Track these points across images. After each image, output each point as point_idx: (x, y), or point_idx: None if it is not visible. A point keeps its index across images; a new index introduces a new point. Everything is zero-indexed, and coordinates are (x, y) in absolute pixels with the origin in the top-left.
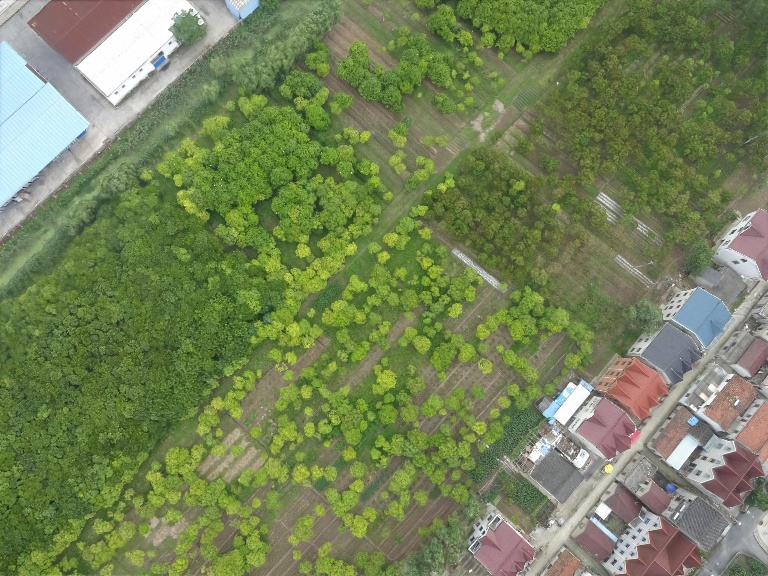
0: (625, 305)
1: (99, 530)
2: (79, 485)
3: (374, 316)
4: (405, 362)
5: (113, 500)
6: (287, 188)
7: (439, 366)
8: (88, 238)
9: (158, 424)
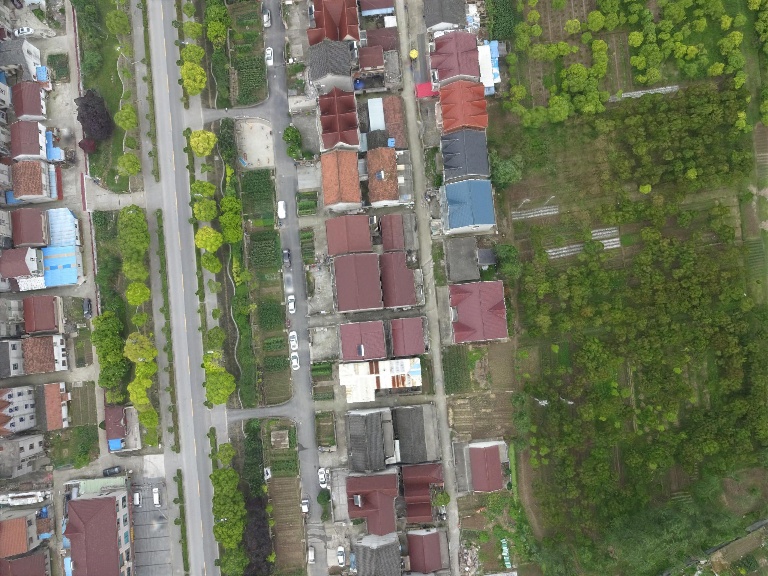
0: None
1: None
2: None
3: None
4: None
5: None
6: None
7: None
8: None
9: None
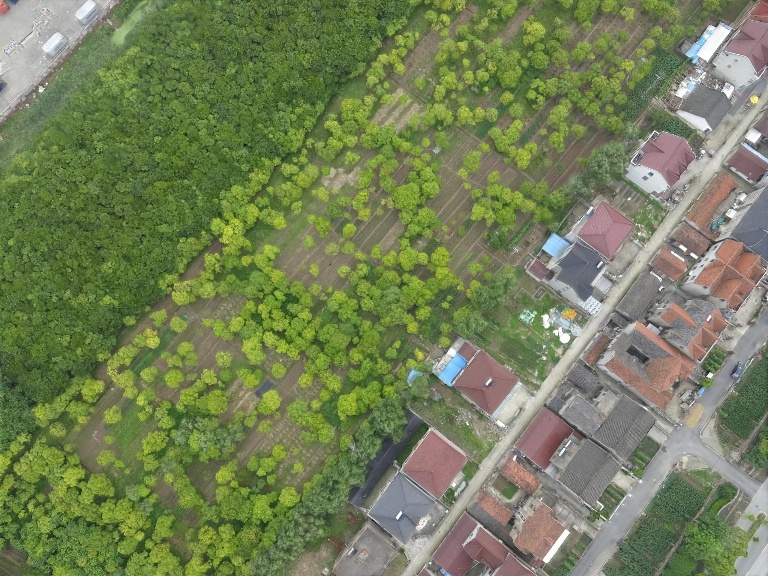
0: None
1: (287, 171)
2: (268, 128)
3: None
4: (549, 21)
5: (298, 144)
6: None
7: (585, 13)
8: None
9: (332, 77)
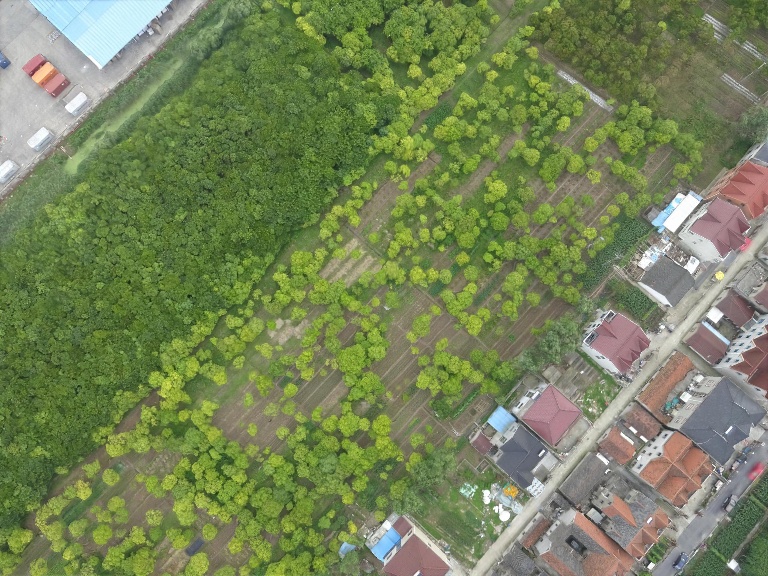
0: (733, 120)
1: (231, 324)
2: (214, 280)
3: (485, 127)
4: (514, 176)
5: (244, 296)
6: (400, 10)
7: (549, 175)
8: (216, 59)
9: (284, 228)
